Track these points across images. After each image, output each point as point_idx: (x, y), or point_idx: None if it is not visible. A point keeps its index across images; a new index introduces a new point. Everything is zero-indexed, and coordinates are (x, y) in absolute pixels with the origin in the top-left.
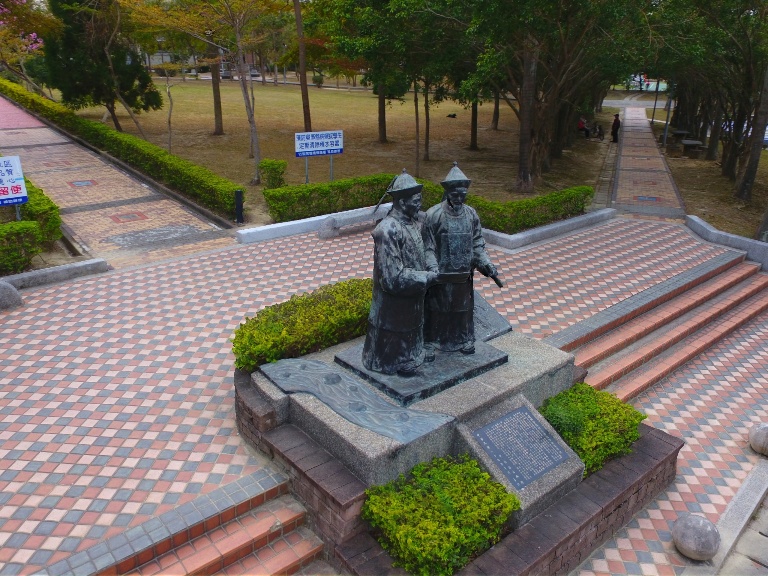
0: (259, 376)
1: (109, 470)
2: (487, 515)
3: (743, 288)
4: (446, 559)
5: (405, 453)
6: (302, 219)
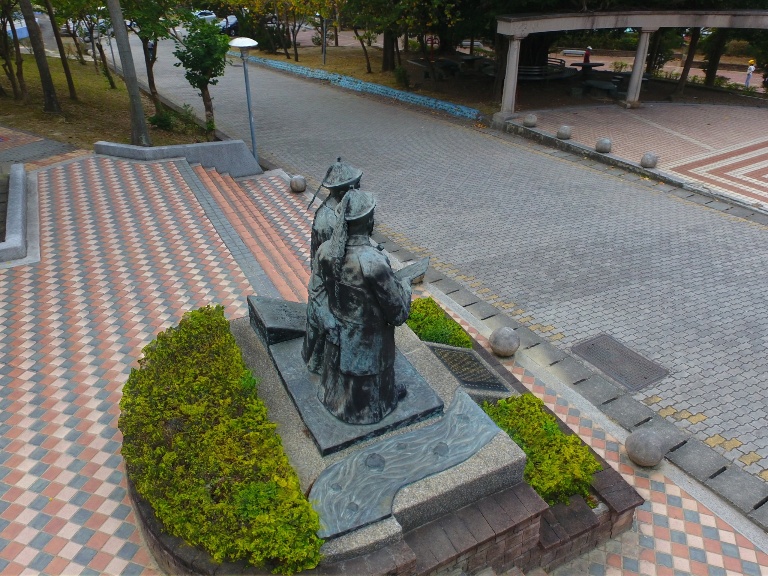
0: (333, 546)
1: None
2: None
3: (222, 188)
4: None
5: None
6: None
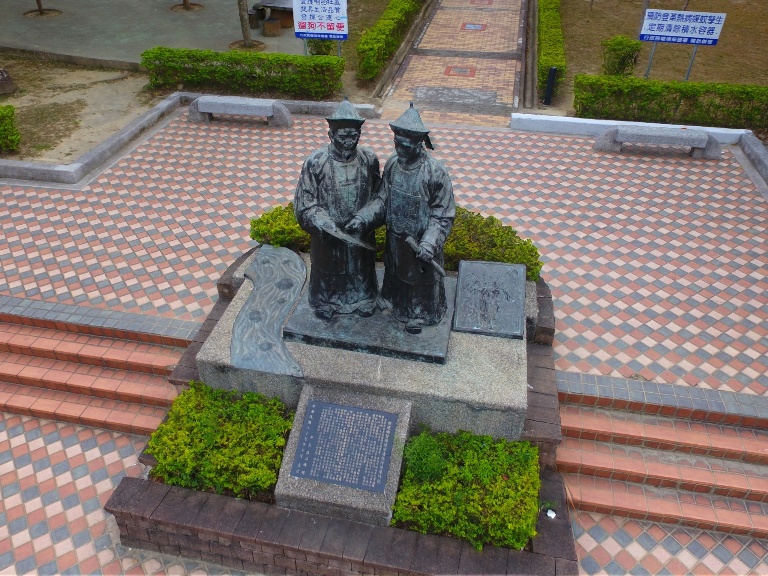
0: None
1: (153, 268)
2: (232, 468)
3: None
4: (169, 469)
5: (237, 375)
6: (598, 119)
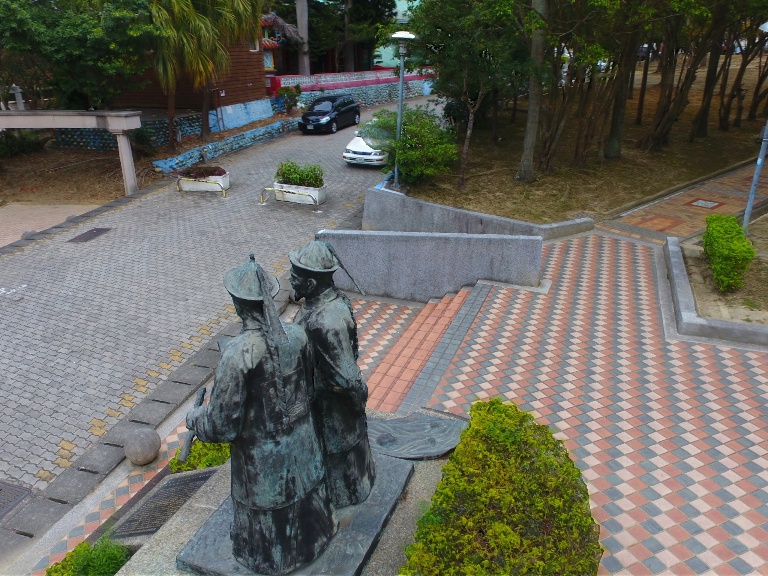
0: None
1: (512, 395)
2: None
3: None
4: None
5: None
6: None
